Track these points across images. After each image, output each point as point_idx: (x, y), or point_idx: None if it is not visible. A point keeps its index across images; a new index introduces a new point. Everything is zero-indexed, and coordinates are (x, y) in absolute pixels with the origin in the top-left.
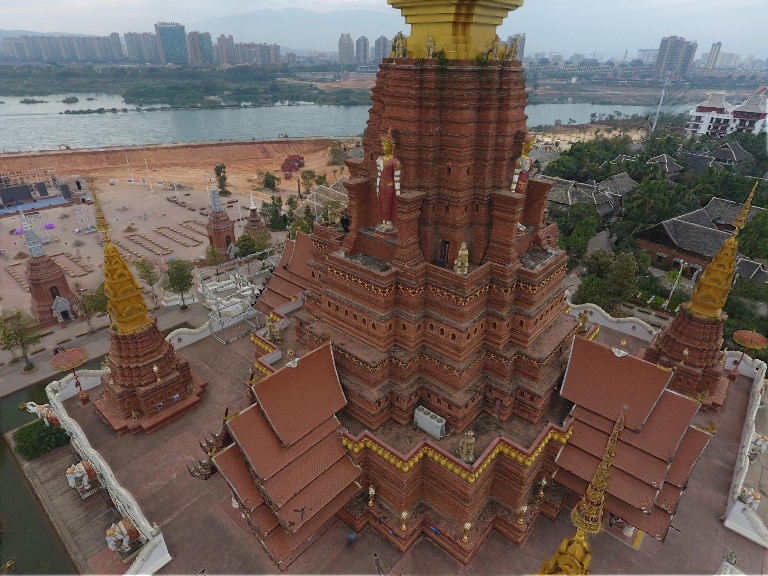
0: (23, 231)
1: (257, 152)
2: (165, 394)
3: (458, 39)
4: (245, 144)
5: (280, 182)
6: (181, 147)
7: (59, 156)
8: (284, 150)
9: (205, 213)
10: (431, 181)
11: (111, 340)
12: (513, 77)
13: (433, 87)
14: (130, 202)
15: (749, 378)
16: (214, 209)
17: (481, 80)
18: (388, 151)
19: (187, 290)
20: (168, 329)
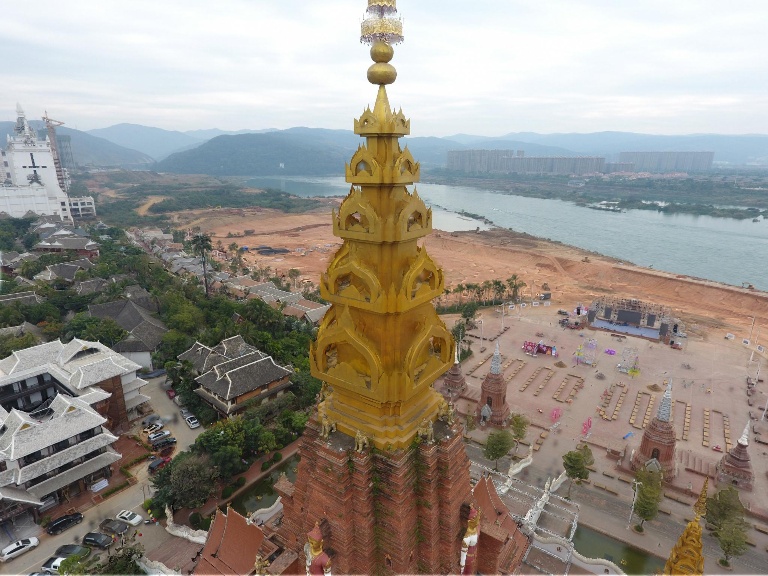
0: (494, 354)
1: None
2: None
3: None
4: None
5: None
6: None
7: (730, 293)
8: None
9: (753, 415)
10: None
11: None
12: (322, 462)
13: None
14: (707, 363)
15: None
16: (657, 415)
17: None
18: None
19: (490, 459)
20: None
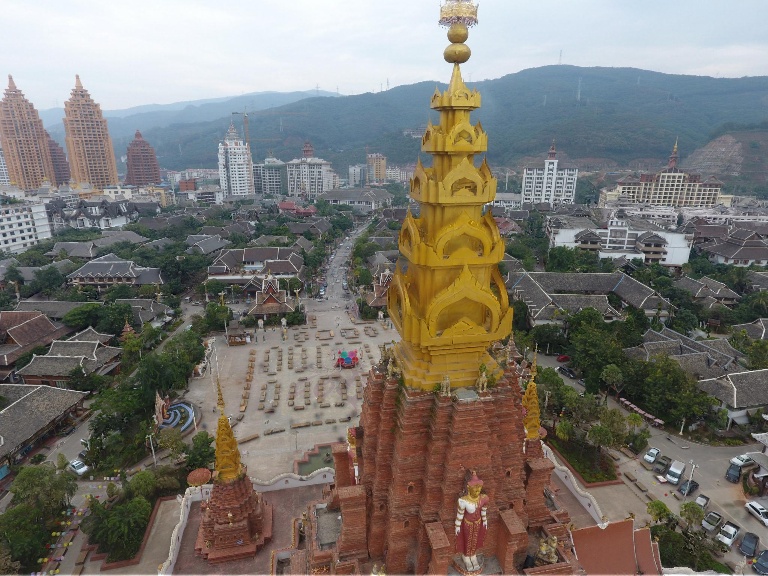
0: None
1: None
2: None
3: None
4: None
5: None
6: None
7: None
8: None
9: None
10: None
11: None
12: None
13: None
14: None
15: (194, 503)
16: None
17: None
18: None
19: None
20: None
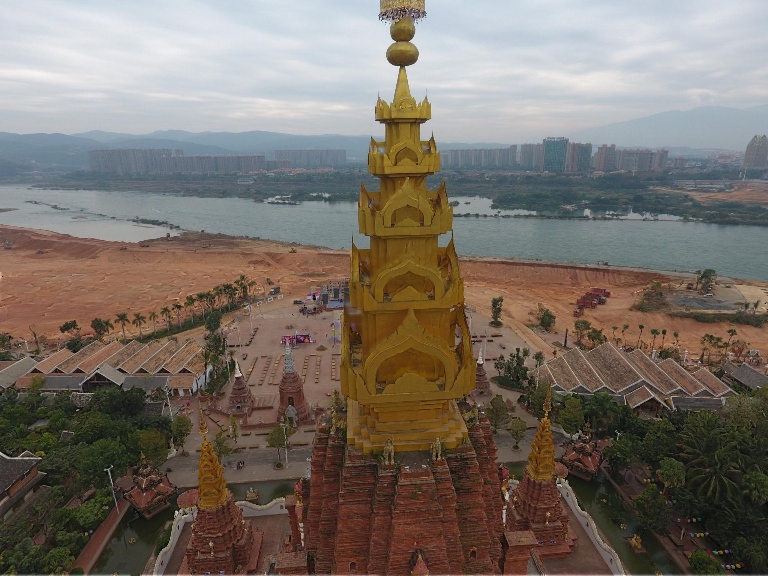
0: None
1: (566, 277)
2: (214, 566)
3: (367, 420)
4: (557, 267)
5: (554, 324)
6: (498, 263)
7: None
8: (596, 279)
9: None
10: (322, 552)
11: (274, 469)
12: (405, 490)
13: (327, 463)
14: None
15: None
16: None
17: (375, 476)
18: (298, 498)
19: None
20: None
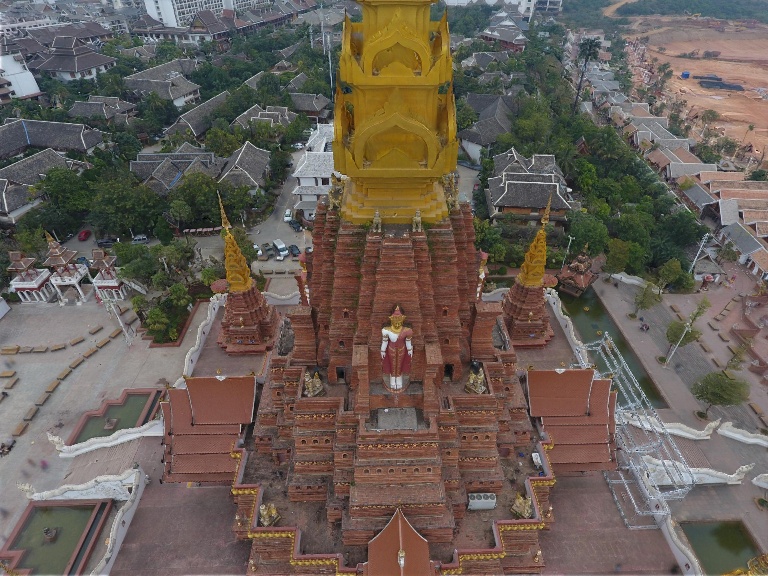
0: None
1: None
2: None
3: None
4: None
5: None
6: None
7: None
8: None
9: None
10: None
11: (656, 357)
12: None
13: None
14: None
15: None
16: None
17: None
18: None
19: None
20: (660, 392)
